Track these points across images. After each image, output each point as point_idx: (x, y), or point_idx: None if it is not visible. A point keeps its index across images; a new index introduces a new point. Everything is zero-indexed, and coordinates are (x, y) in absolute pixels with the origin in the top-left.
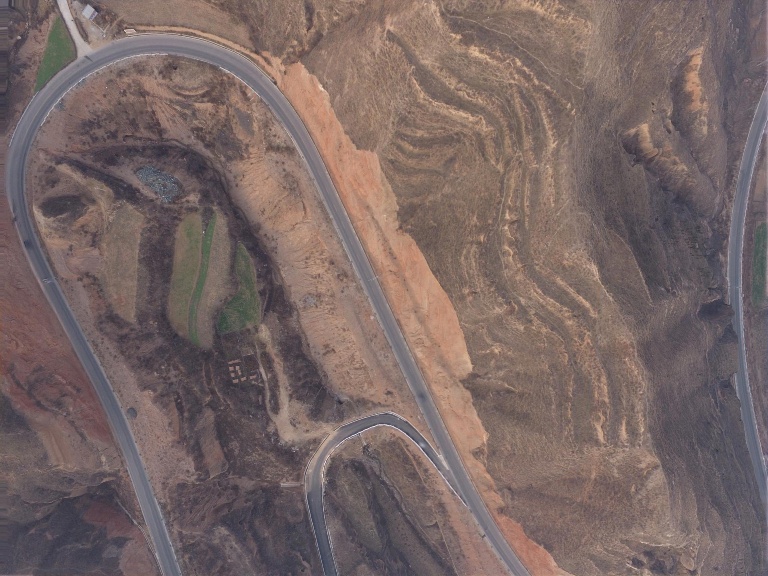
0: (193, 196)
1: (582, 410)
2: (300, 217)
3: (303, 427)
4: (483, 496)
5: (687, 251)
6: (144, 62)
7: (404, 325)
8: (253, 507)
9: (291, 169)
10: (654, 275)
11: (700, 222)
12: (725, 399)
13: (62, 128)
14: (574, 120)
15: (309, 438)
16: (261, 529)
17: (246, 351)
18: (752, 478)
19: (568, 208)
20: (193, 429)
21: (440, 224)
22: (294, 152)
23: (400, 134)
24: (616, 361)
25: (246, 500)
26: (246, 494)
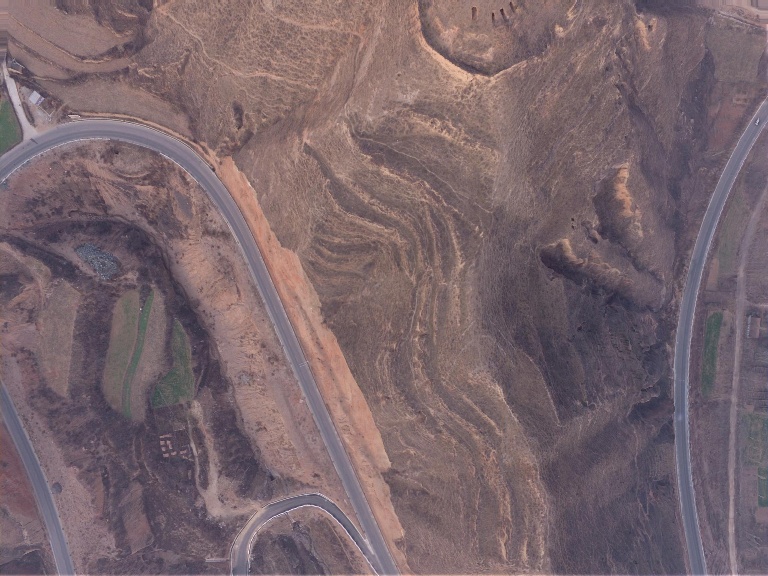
0: (131, 274)
1: (488, 524)
2: (235, 299)
3: (231, 503)
4: None
5: (615, 357)
6: (87, 146)
7: (333, 410)
8: None
9: (226, 253)
10: (570, 388)
11: (639, 319)
12: (658, 500)
13: (5, 207)
14: (482, 243)
15: (237, 514)
16: None
17: (178, 426)
18: None
19: (472, 330)
20: (117, 505)
21: (360, 324)
22: (229, 237)
23: (318, 239)
24: (520, 481)
25: (169, 575)
26: (170, 568)
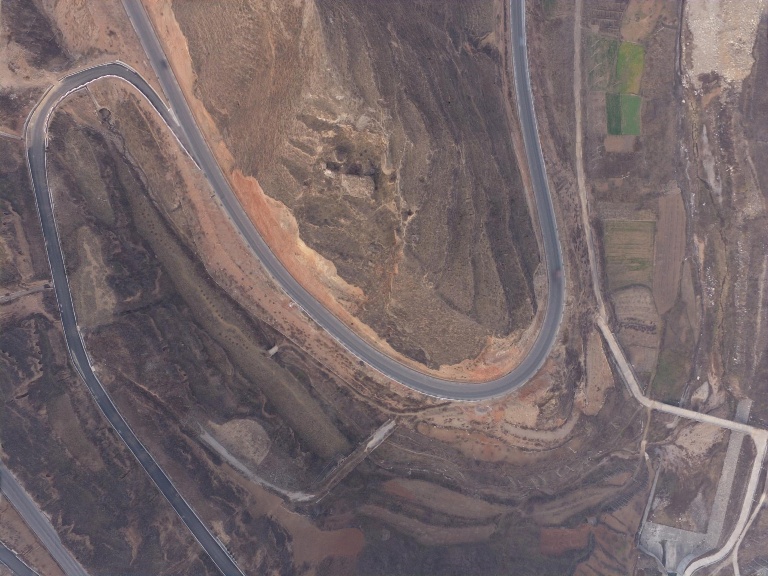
0: None
1: None
2: None
3: (23, 73)
4: (218, 159)
5: None
6: None
7: None
8: None
9: None
10: None
11: None
12: (476, 57)
13: None
14: None
15: (30, 86)
16: None
17: None
18: (507, 146)
19: None
20: None
21: None
22: None
23: None
24: None
25: None
26: None
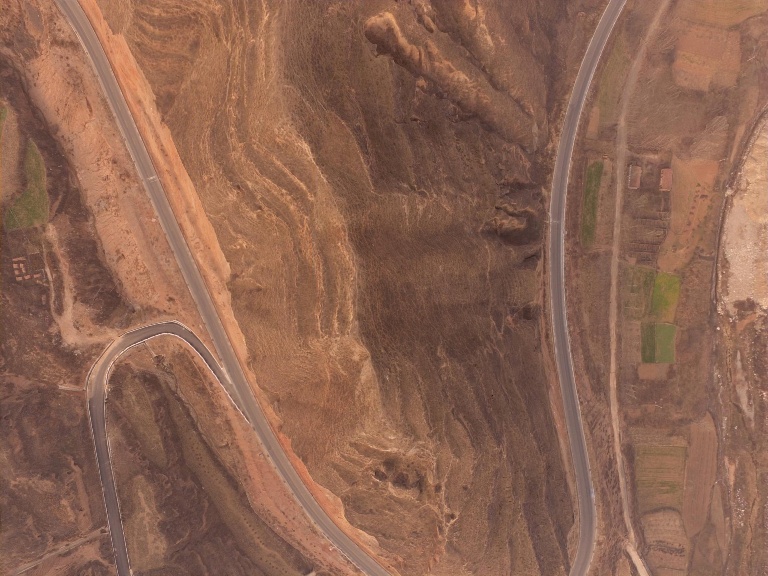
0: None
1: (306, 301)
2: (87, 115)
3: (86, 331)
4: (266, 414)
5: (459, 160)
6: None
7: (185, 229)
8: (24, 405)
9: (75, 64)
10: (398, 171)
11: (501, 144)
12: (517, 327)
13: None
14: None
15: (92, 342)
16: (29, 427)
17: (32, 249)
18: (545, 412)
19: (275, 81)
20: None
21: (190, 112)
22: (78, 47)
23: (139, 13)
24: (332, 247)
25: (18, 398)
26: (21, 393)
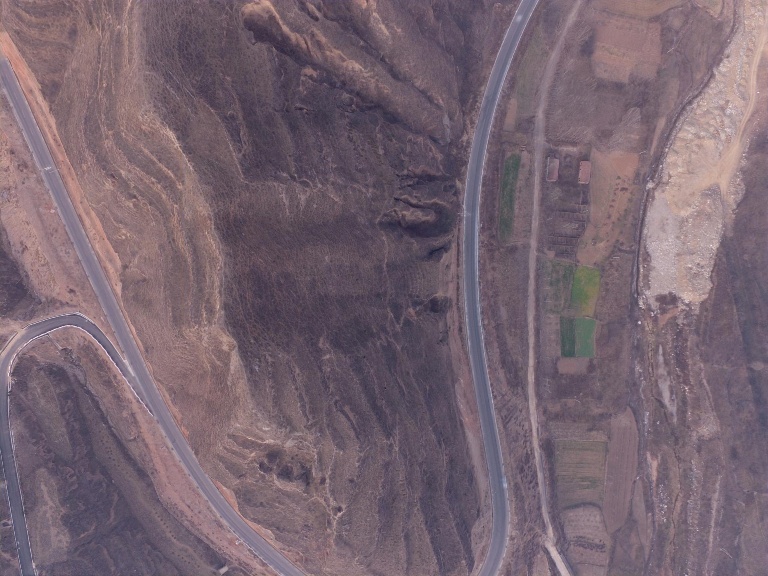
0: None
1: (180, 291)
2: None
3: None
4: (170, 407)
5: (350, 150)
6: None
7: (84, 221)
8: None
9: None
10: (277, 160)
11: (406, 135)
12: (420, 319)
13: None
14: None
15: None
16: None
17: None
18: (448, 405)
19: (137, 67)
20: None
21: (72, 101)
22: None
23: None
24: (200, 236)
25: None
26: None
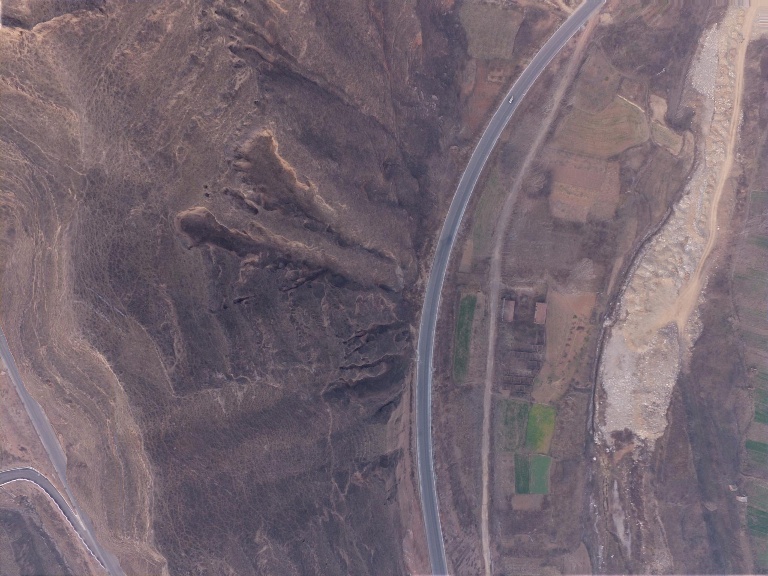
0: None
1: (114, 496)
2: None
3: None
4: None
5: (292, 332)
6: None
7: None
8: None
9: None
10: (213, 361)
11: (354, 296)
12: (367, 481)
13: None
14: (76, 206)
15: None
16: None
17: None
18: (395, 565)
19: (66, 295)
20: None
21: (13, 292)
22: None
23: None
24: (132, 451)
25: None
26: None
